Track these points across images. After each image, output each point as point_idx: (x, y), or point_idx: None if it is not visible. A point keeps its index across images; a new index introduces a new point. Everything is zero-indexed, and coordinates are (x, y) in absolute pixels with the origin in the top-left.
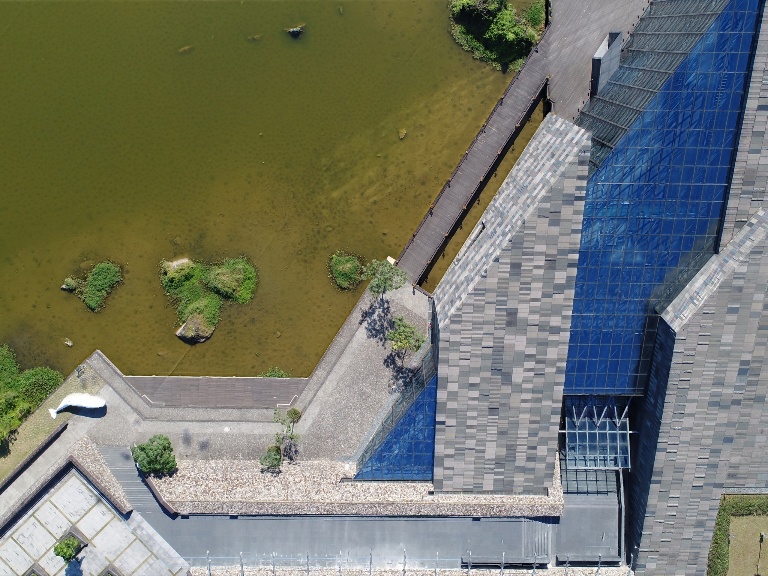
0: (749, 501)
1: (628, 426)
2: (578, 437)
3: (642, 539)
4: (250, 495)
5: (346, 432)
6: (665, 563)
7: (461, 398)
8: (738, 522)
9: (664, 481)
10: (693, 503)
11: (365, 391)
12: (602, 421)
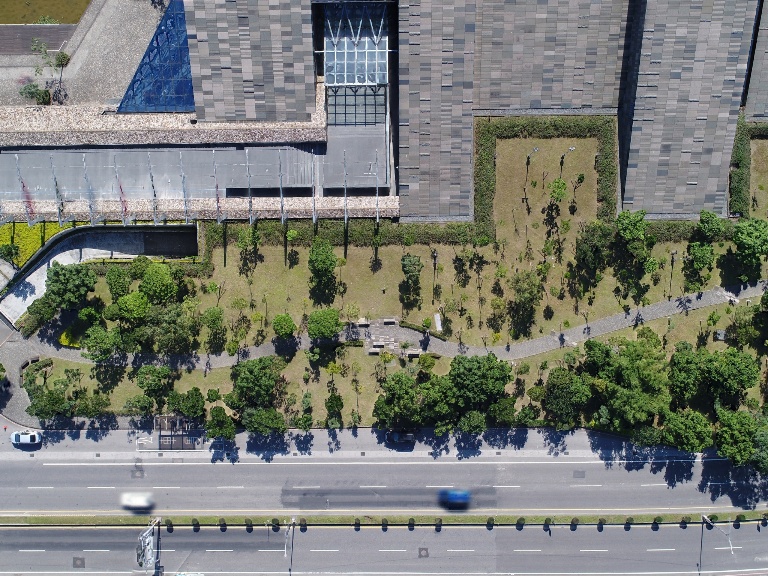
0: (513, 121)
1: (387, 44)
2: (336, 56)
3: (400, 154)
4: (11, 126)
5: (115, 75)
6: (428, 183)
7: (208, 6)
8: (504, 145)
9: (412, 81)
10: (445, 108)
11: (133, 33)
12: (361, 41)
